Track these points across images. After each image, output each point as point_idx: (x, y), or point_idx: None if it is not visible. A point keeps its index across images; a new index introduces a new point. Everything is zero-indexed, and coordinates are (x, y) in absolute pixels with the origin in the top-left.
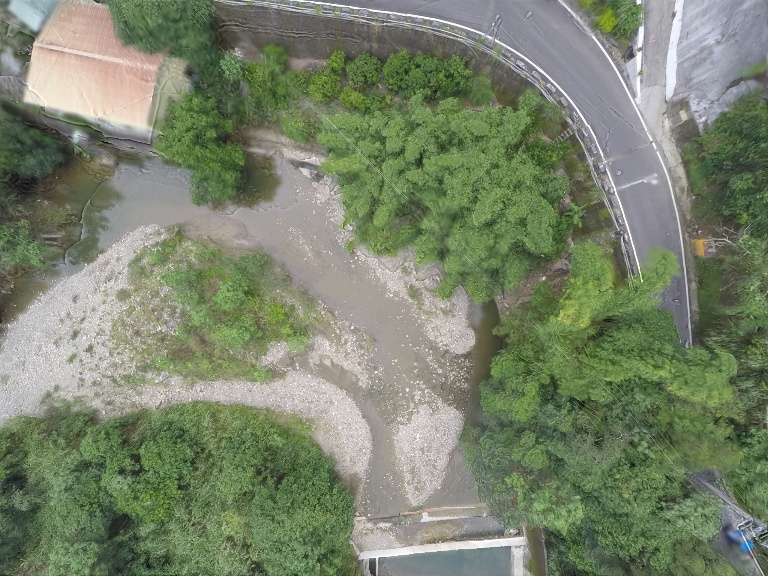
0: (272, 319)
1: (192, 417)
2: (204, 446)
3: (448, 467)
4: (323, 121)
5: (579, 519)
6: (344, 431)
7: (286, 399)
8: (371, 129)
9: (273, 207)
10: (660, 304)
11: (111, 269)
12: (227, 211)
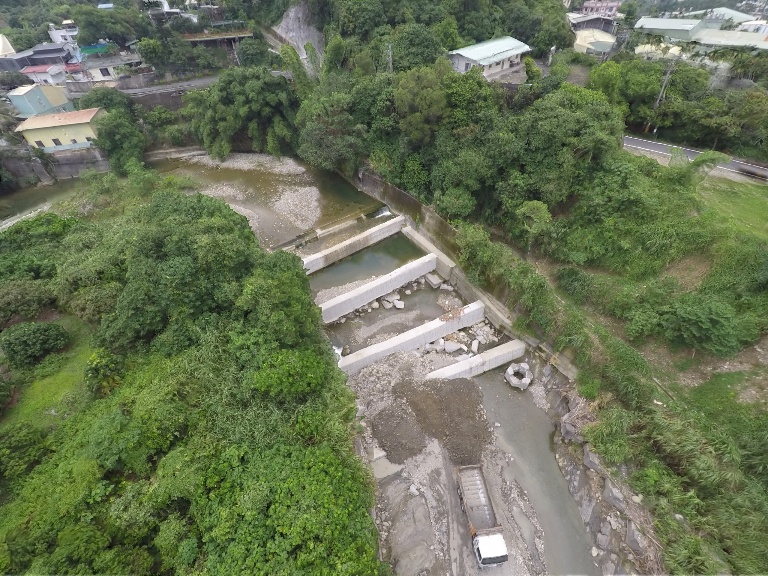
0: (164, 182)
1: None
2: None
3: (320, 206)
4: (184, 114)
5: None
6: None
7: None
8: (203, 92)
9: (163, 172)
10: (310, 44)
11: (32, 216)
12: (132, 157)
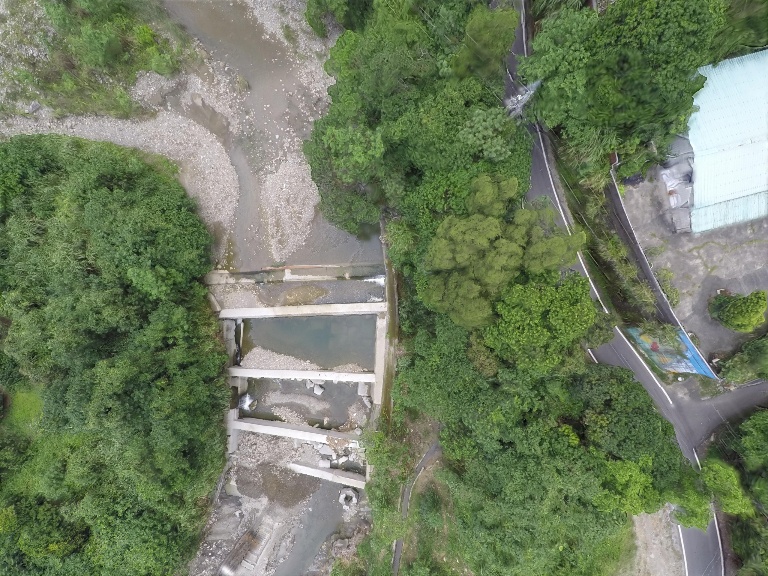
0: (139, 39)
1: (54, 140)
2: (61, 164)
3: (313, 222)
4: None
5: (379, 152)
6: (211, 176)
7: (155, 140)
8: None
9: None
10: None
11: None
12: None
